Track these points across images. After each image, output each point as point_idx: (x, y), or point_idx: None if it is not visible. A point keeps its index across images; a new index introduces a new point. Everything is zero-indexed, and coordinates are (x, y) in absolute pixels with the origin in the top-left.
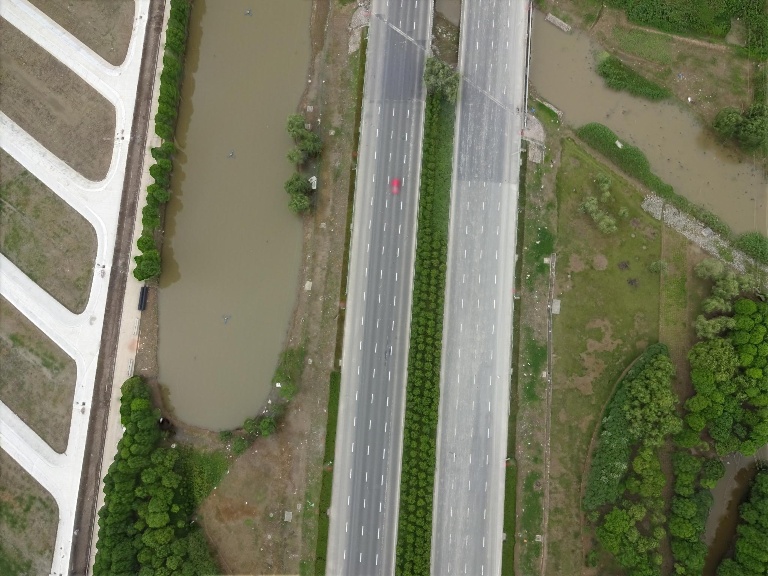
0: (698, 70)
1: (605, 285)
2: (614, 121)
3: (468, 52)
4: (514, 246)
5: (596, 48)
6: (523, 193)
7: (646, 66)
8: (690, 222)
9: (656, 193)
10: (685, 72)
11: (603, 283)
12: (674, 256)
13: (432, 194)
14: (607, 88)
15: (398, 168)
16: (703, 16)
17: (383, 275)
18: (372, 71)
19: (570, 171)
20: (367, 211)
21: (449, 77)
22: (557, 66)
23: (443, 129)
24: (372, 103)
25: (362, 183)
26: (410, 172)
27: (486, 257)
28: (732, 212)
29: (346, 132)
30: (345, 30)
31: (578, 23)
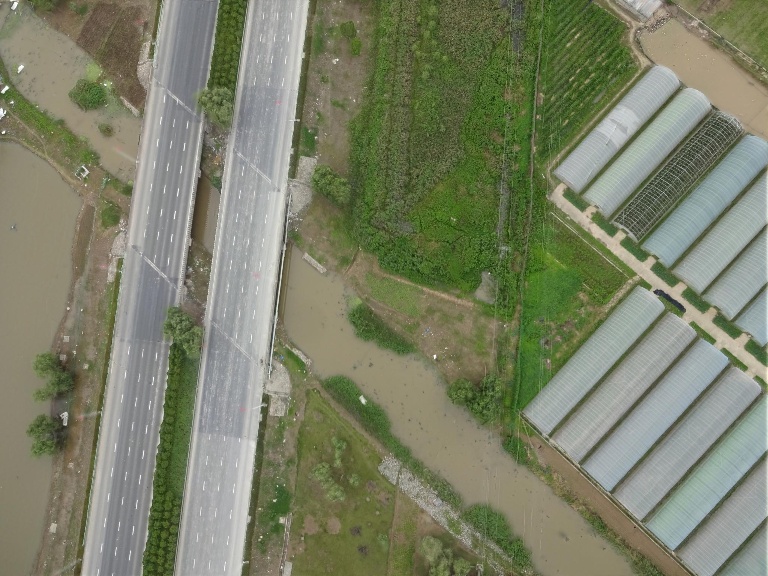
0: (445, 326)
1: (336, 550)
2: (360, 374)
3: (218, 295)
4: (247, 507)
5: (350, 293)
6: (261, 451)
7: (396, 317)
8: (424, 489)
9: (394, 455)
10: (432, 327)
11: (334, 548)
12: (405, 525)
13: (170, 449)
14: (357, 338)
15: (143, 414)
16: (452, 271)
17: (121, 527)
18: (125, 307)
19: (313, 426)
20: (110, 458)
21: (185, 334)
22: (310, 310)
23: (187, 378)
24: (122, 342)
25: (107, 427)
26: (154, 419)
27: (220, 516)
28: (467, 480)
29: (98, 369)
30: (106, 256)
31: (333, 265)
